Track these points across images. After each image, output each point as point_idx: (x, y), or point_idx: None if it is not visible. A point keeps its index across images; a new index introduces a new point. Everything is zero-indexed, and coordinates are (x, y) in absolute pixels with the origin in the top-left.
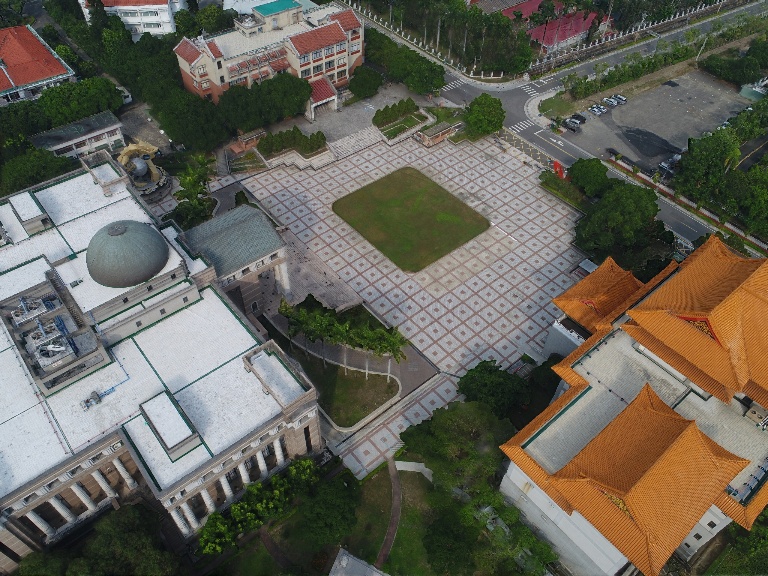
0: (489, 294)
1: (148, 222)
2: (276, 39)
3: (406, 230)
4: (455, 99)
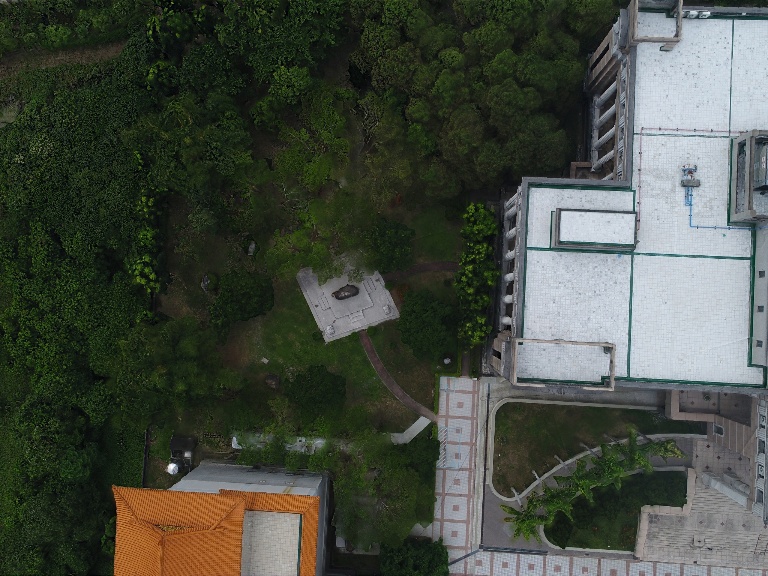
0: None
1: None
2: None
3: None
4: None
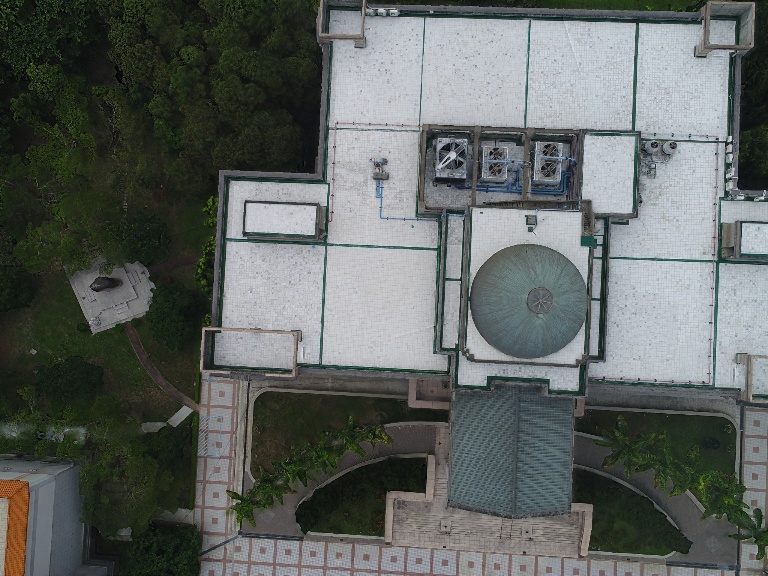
0: None
1: (633, 374)
2: None
3: None
4: None
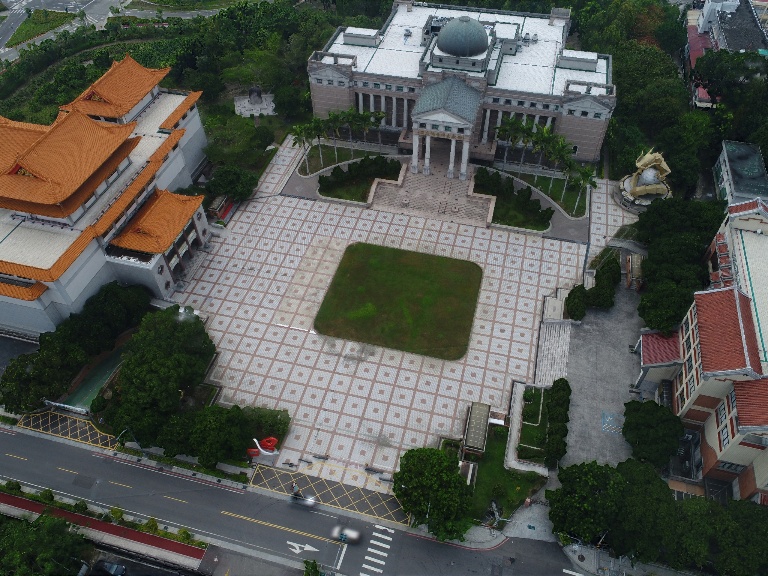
0: (275, 259)
1: None
2: (767, 303)
3: (390, 277)
4: (529, 552)
